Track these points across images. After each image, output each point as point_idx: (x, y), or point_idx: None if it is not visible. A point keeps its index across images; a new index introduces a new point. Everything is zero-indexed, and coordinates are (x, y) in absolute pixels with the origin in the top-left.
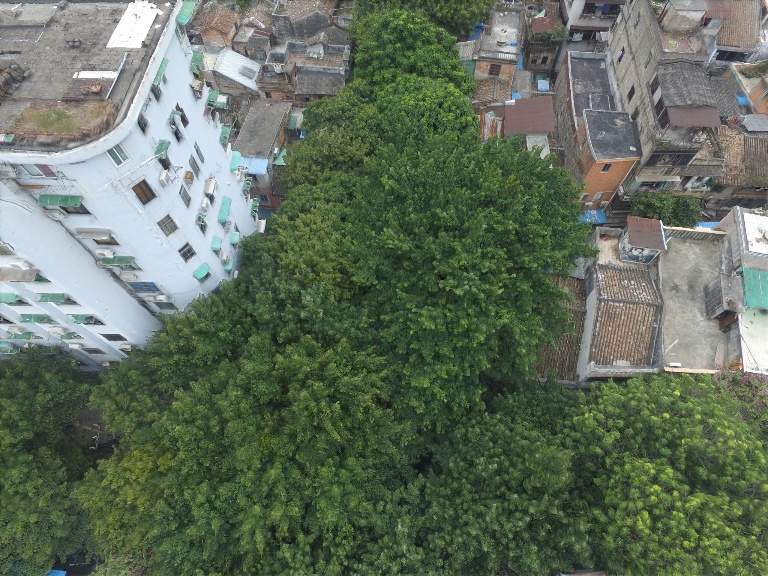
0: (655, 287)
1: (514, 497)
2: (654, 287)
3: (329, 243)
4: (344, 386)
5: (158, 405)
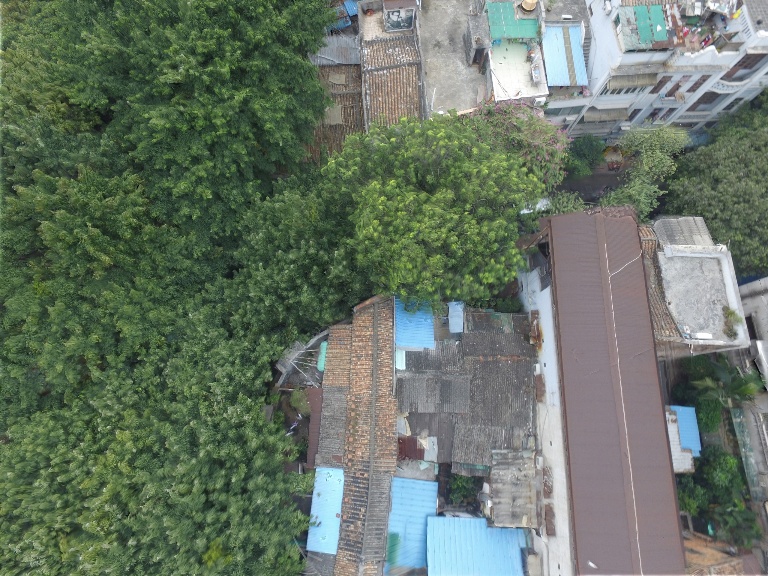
0: (417, 47)
1: None
2: (416, 48)
3: (34, 71)
4: (97, 210)
5: None
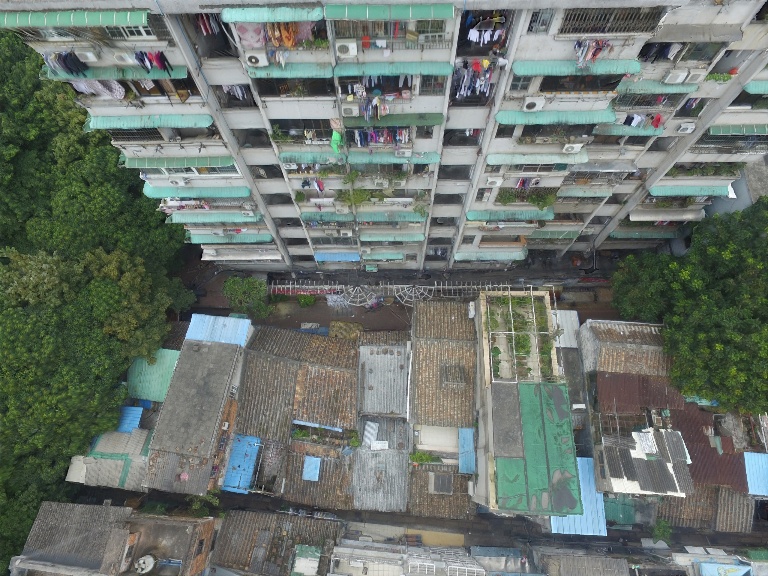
0: None
1: None
2: None
3: None
4: None
5: None
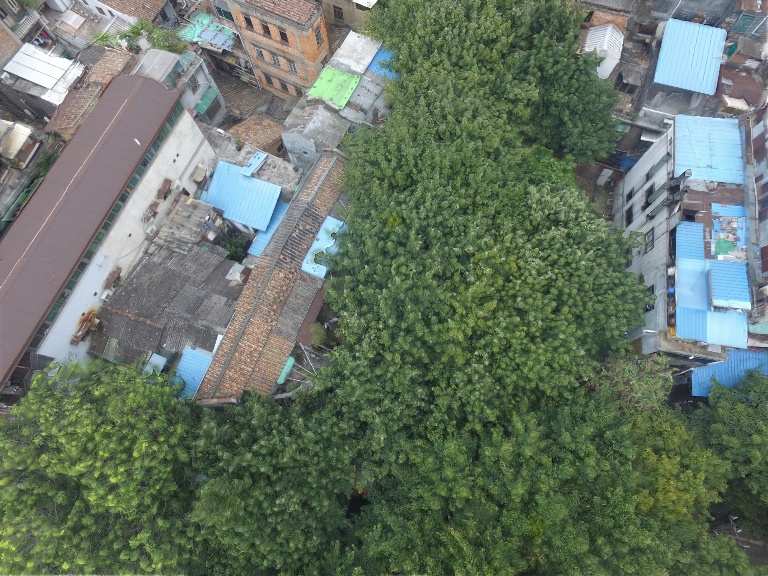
0: None
1: (264, 468)
2: None
3: None
4: None
5: (684, 574)
